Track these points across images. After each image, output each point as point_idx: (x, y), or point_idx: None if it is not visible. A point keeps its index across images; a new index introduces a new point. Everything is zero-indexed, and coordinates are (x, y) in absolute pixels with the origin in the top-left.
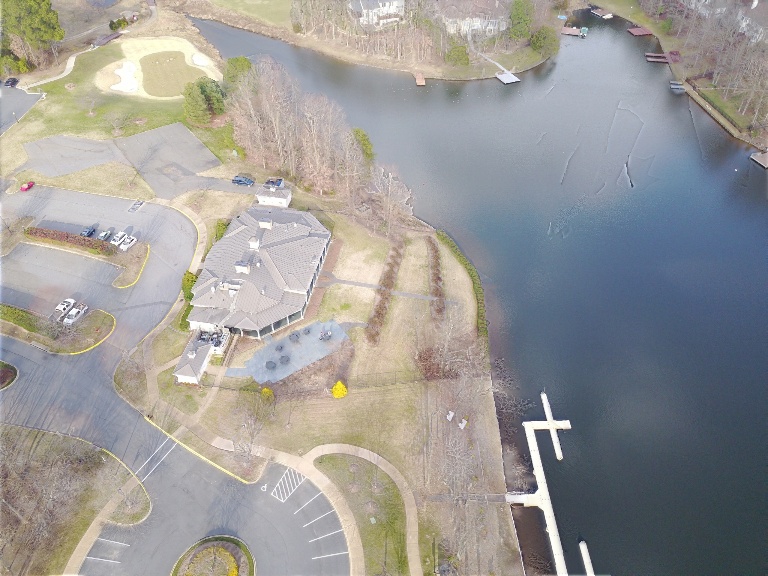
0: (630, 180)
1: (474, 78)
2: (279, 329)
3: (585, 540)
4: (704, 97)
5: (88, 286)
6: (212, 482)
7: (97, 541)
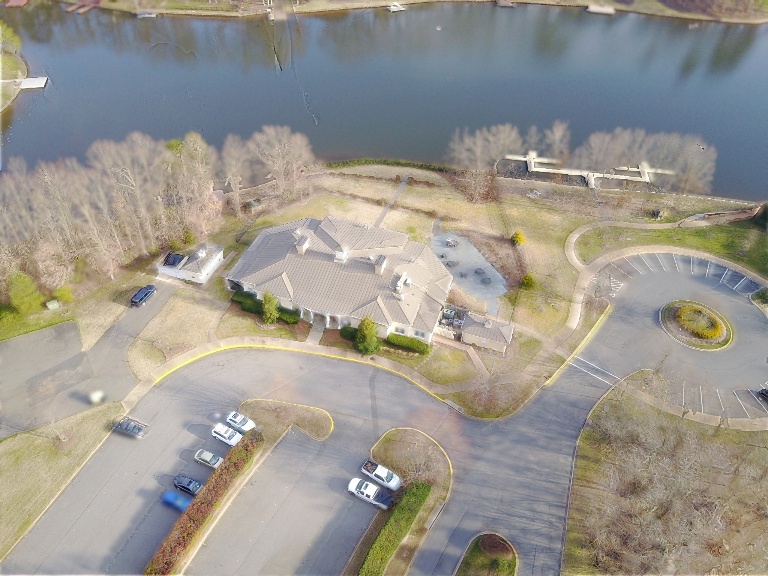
0: (279, 65)
1: (9, 102)
2: None
3: (613, 167)
4: (176, 8)
5: (319, 471)
6: (612, 328)
7: None
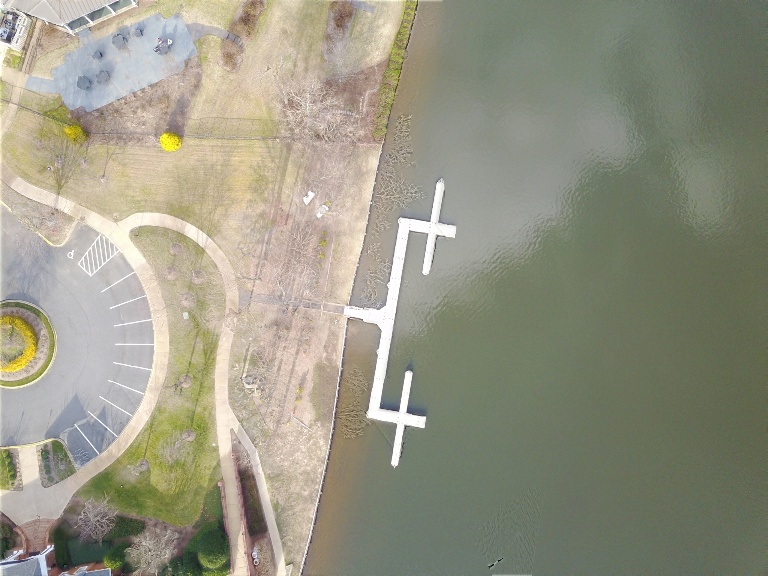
0: None
1: None
2: (100, 20)
3: (414, 369)
4: None
5: None
6: (12, 236)
7: None
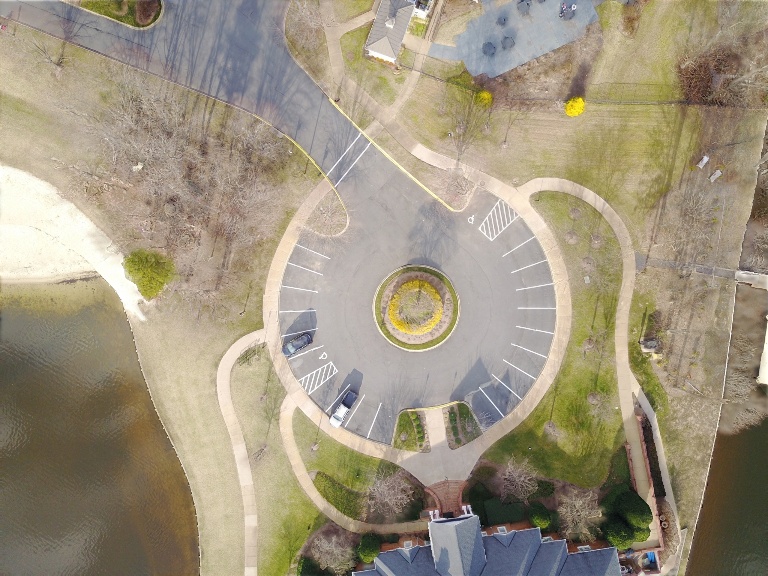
0: None
1: None
2: None
3: None
4: None
5: None
6: (413, 202)
7: (296, 247)
